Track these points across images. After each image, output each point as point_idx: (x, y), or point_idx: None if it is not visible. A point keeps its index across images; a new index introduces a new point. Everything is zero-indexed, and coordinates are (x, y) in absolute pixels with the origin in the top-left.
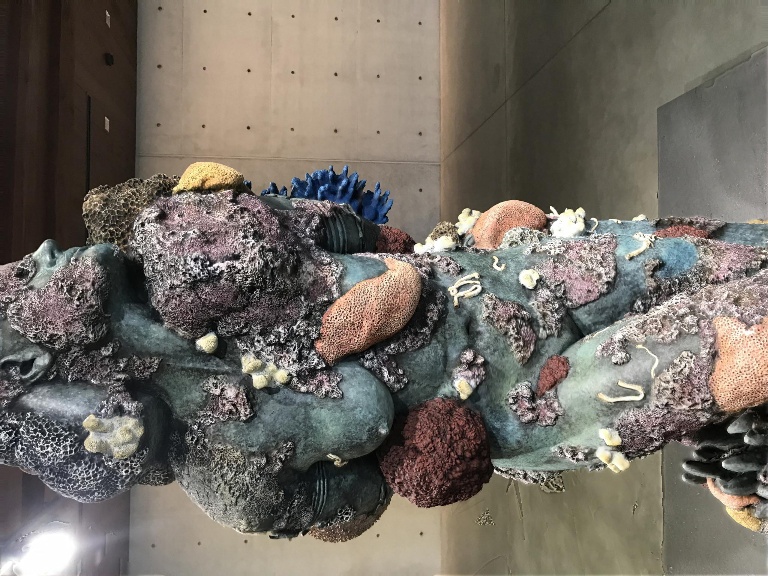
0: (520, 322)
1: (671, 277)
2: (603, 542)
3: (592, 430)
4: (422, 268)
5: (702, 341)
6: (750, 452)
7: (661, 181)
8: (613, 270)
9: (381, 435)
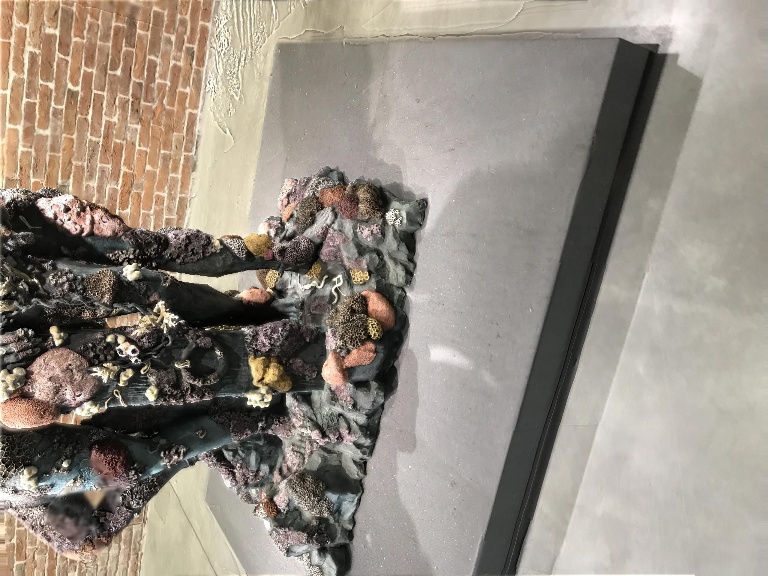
0: None
1: None
2: None
3: None
4: None
5: None
6: None
7: (519, 47)
8: None
9: None
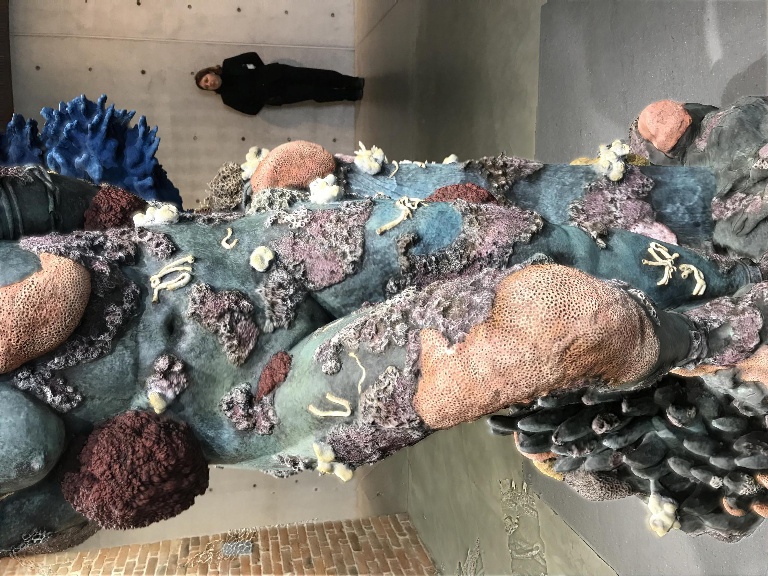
0: (237, 316)
1: (428, 254)
2: (483, 443)
3: (307, 442)
4: (117, 254)
5: (407, 356)
6: (545, 412)
7: (540, 89)
8: (360, 248)
9: (34, 470)
